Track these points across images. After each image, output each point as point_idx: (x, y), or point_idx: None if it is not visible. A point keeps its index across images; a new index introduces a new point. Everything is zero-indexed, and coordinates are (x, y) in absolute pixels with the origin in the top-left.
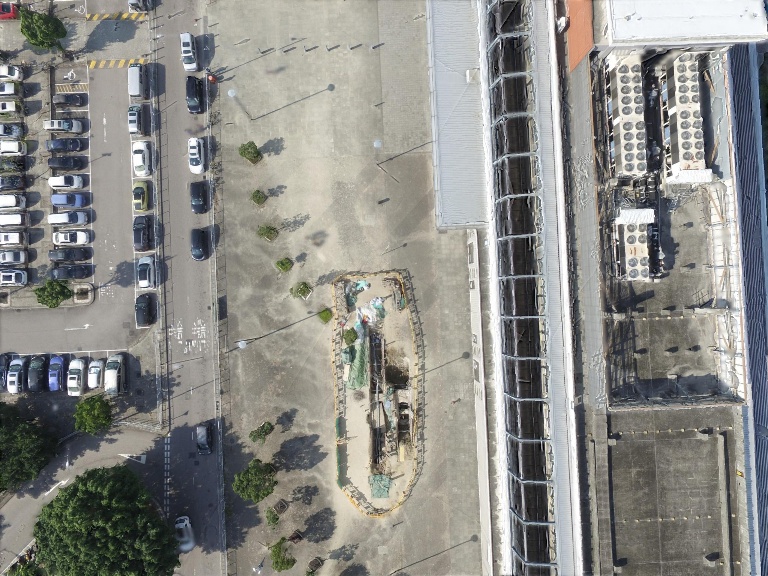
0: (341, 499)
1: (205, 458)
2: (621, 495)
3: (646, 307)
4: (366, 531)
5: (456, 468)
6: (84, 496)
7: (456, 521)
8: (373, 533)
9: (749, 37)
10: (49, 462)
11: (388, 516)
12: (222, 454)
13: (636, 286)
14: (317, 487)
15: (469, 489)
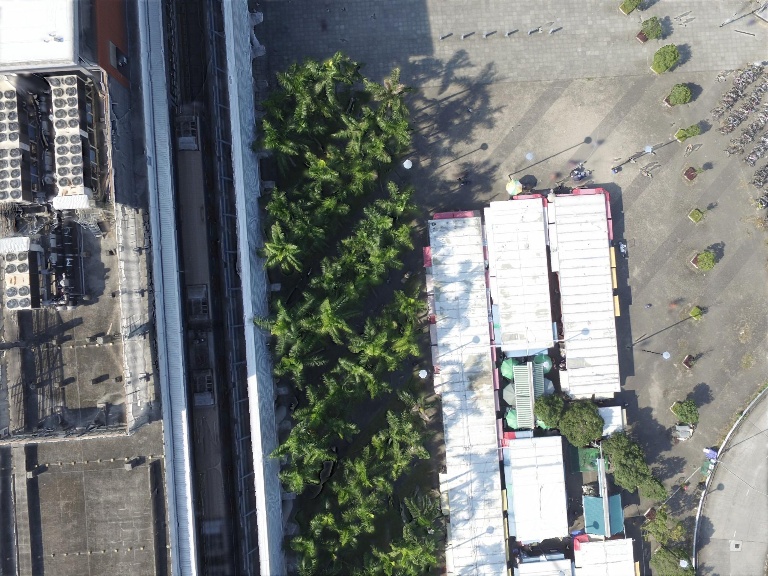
0: None
1: None
2: (50, 528)
3: (73, 335)
4: None
5: None
6: None
7: None
8: None
9: (52, 62)
10: None
11: None
12: None
13: (63, 314)
14: None
15: None
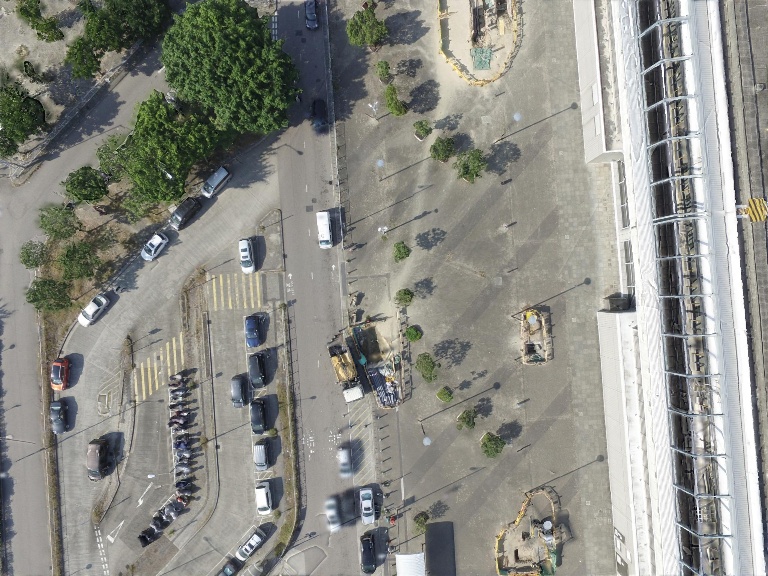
0: (444, 71)
1: (311, 35)
2: None
3: None
4: (469, 102)
5: (554, 40)
6: (212, 4)
7: (556, 90)
8: (476, 104)
9: None
10: (161, 40)
11: (490, 87)
12: (328, 29)
13: None
14: (421, 60)
15: (568, 59)
